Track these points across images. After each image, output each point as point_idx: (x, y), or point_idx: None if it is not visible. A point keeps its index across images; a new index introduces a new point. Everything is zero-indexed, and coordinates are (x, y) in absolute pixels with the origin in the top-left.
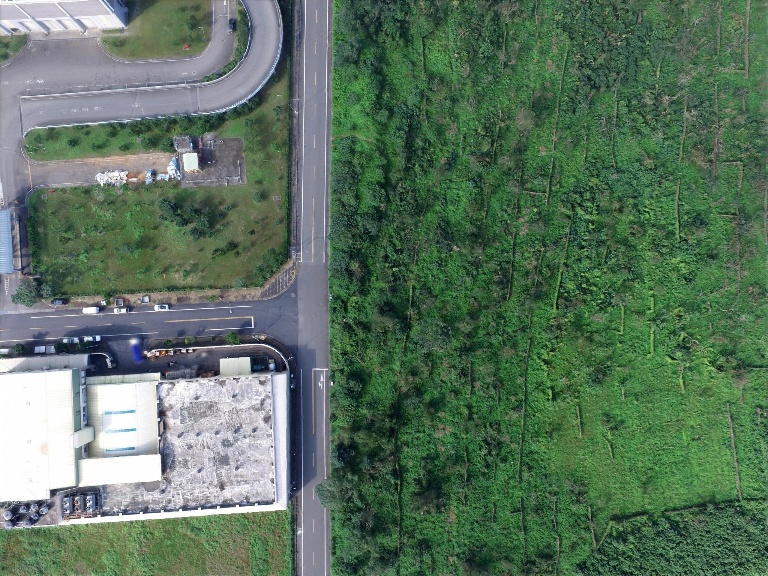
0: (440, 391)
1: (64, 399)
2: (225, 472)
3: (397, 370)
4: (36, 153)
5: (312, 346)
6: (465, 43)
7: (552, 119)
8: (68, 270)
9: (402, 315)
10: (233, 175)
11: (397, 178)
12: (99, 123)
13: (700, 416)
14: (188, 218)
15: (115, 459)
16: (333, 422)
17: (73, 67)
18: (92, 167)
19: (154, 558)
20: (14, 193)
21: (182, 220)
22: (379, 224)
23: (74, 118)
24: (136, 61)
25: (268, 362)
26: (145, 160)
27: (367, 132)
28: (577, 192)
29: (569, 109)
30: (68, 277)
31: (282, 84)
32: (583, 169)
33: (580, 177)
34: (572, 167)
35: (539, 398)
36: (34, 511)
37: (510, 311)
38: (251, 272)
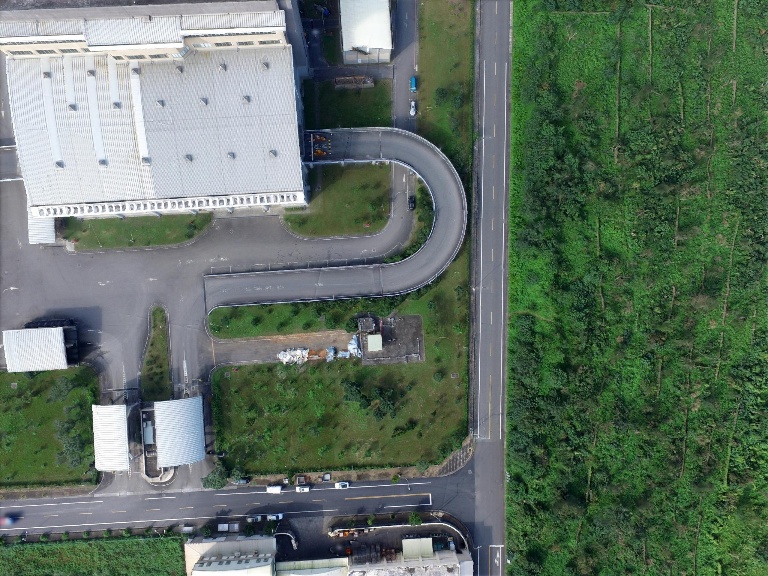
0: (615, 569)
1: None
2: None
3: (572, 547)
4: (220, 331)
5: (488, 523)
6: (643, 223)
7: (722, 293)
8: (251, 448)
9: (578, 494)
10: (412, 352)
11: (577, 360)
12: (283, 303)
13: None
14: (368, 396)
15: None
16: None
17: (256, 245)
18: (274, 345)
19: None
20: (198, 371)
21: (367, 402)
22: (562, 408)
23: (257, 296)
24: (317, 238)
25: (447, 541)
26: (326, 337)
27: (546, 312)
28: (746, 366)
29: (740, 284)
30: (256, 460)
31: (460, 261)
32: (752, 343)
33: (749, 351)
34: (740, 340)
35: (707, 571)
36: None
37: (682, 487)
38: (429, 449)
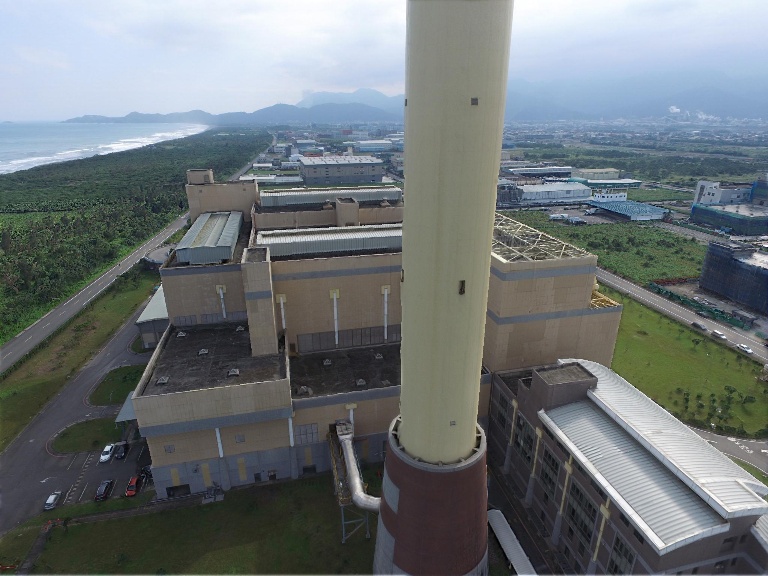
0: None
1: None
2: None
3: None
4: None
5: None
6: None
7: None
8: None
9: None
10: None
11: None
12: None
13: (1, 221)
14: None
15: None
16: None
17: None
18: None
19: None
20: None
21: None
22: None
23: None
24: None
25: None
26: None
27: None
28: None
29: None
30: None
31: None
32: None
33: None
34: None
35: None
36: None
37: None
38: None
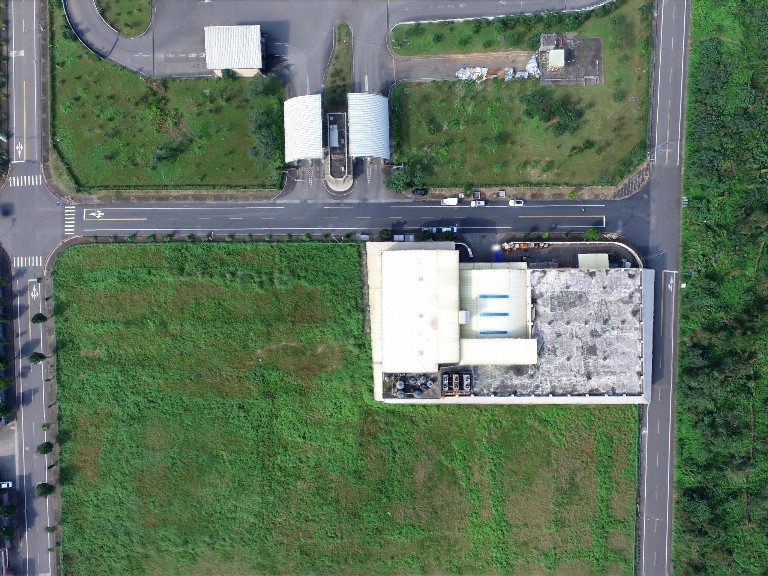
0: None
1: (452, 278)
2: (592, 362)
3: (750, 276)
4: (401, 48)
5: (663, 248)
6: None
7: None
8: (428, 162)
9: None
10: (591, 75)
11: (766, 80)
12: (465, 19)
13: None
14: None
15: (494, 340)
16: (686, 324)
17: None
18: (453, 63)
19: (502, 446)
20: (378, 86)
21: (548, 115)
22: (750, 125)
23: (439, 14)
24: None
25: (622, 260)
26: (504, 58)
27: (733, 34)
28: None
29: None
30: None
31: None
32: None
33: None
34: None
35: None
36: (420, 384)
37: None
38: (605, 171)
